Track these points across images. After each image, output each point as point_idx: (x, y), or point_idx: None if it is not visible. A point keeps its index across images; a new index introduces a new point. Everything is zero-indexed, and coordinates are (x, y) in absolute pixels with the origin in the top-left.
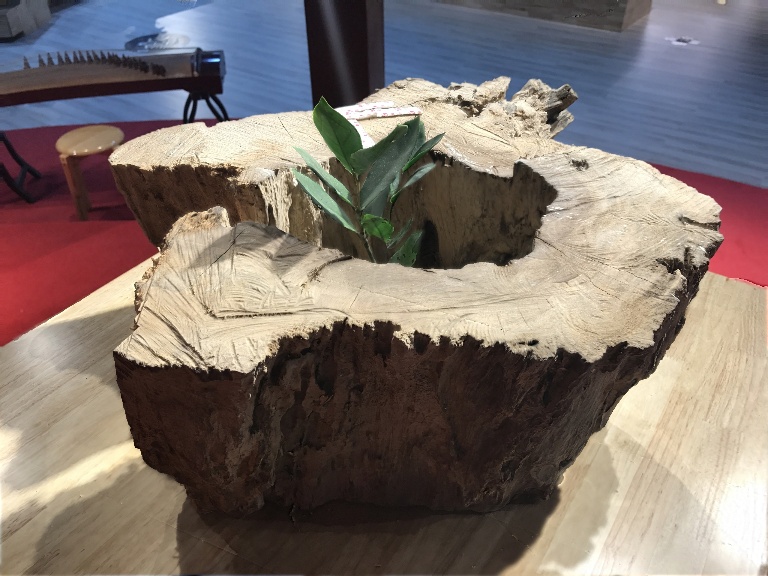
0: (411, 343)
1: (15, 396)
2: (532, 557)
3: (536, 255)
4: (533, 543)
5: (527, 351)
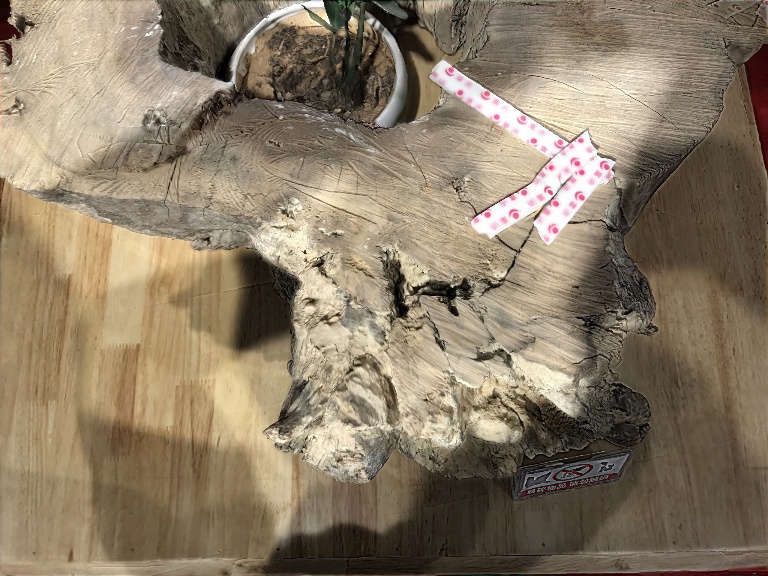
0: None
1: None
2: None
3: None
4: None
5: None
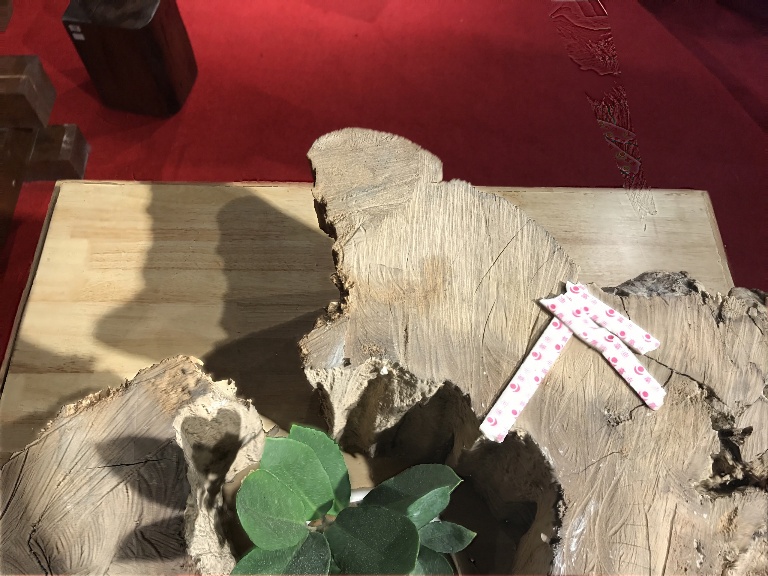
0: None
1: (172, 247)
2: None
3: None
4: None
5: None
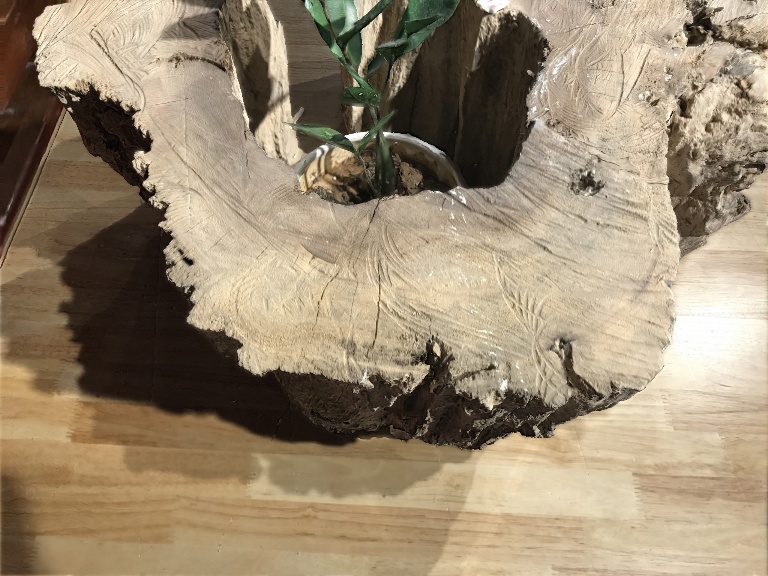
0: (143, 171)
1: None
2: (265, 443)
3: (340, 210)
4: (280, 439)
5: (173, 261)
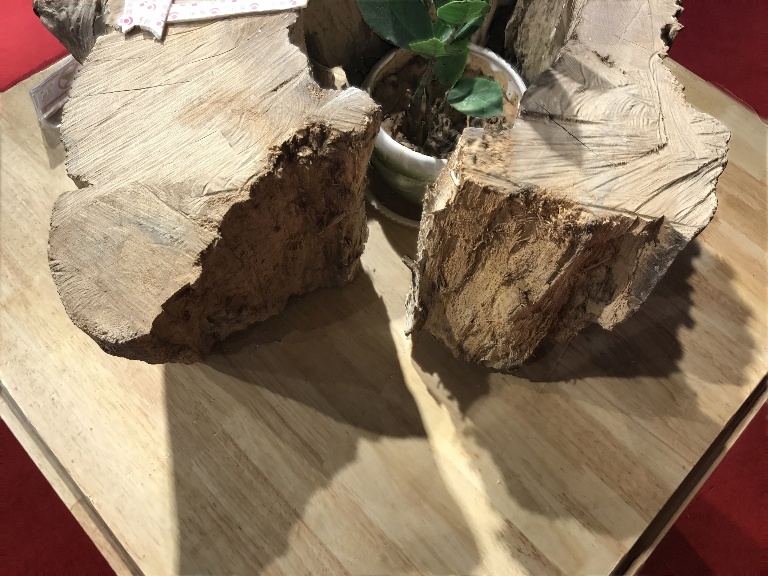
0: None
1: None
2: None
3: None
4: None
5: None
